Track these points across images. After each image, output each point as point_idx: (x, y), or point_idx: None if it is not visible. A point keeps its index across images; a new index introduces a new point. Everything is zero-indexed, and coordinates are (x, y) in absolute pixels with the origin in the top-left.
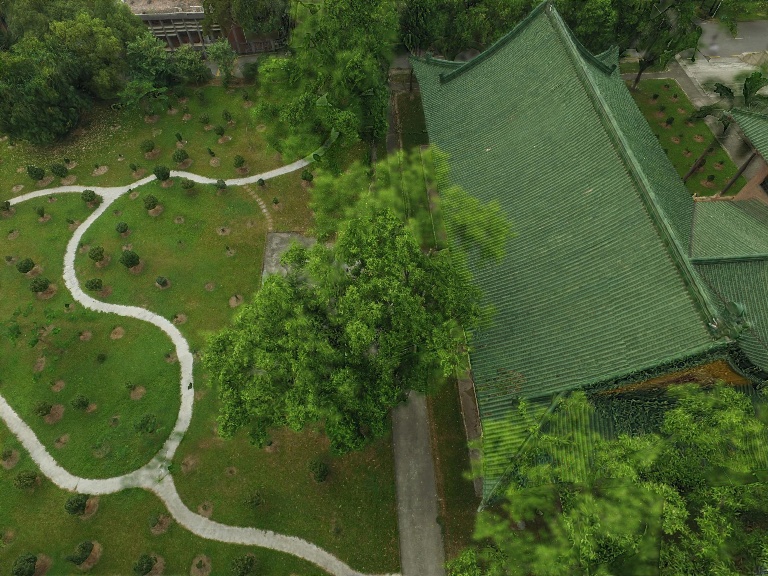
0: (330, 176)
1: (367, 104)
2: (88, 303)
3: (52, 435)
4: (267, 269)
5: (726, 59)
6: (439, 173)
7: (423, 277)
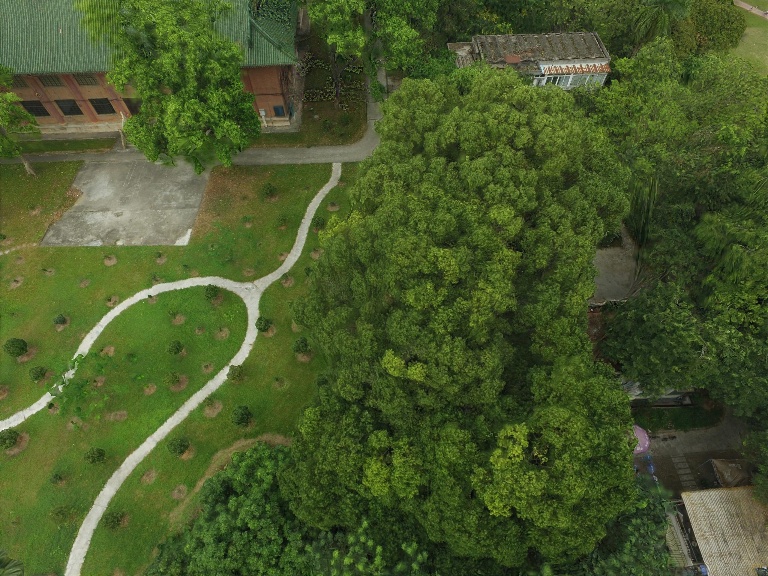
0: None
1: None
2: None
3: (199, 377)
4: (84, 244)
5: None
6: (62, 69)
7: (171, 4)
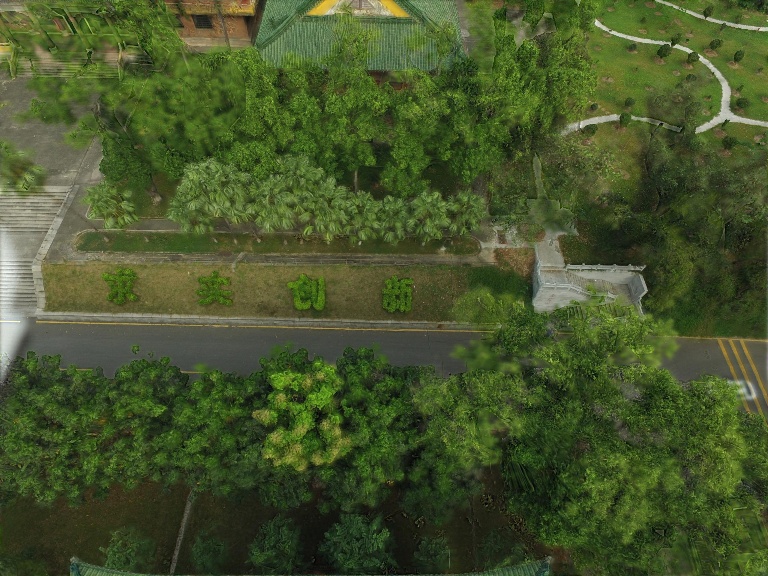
0: None
1: None
2: (676, 45)
3: None
4: None
5: None
6: None
7: None
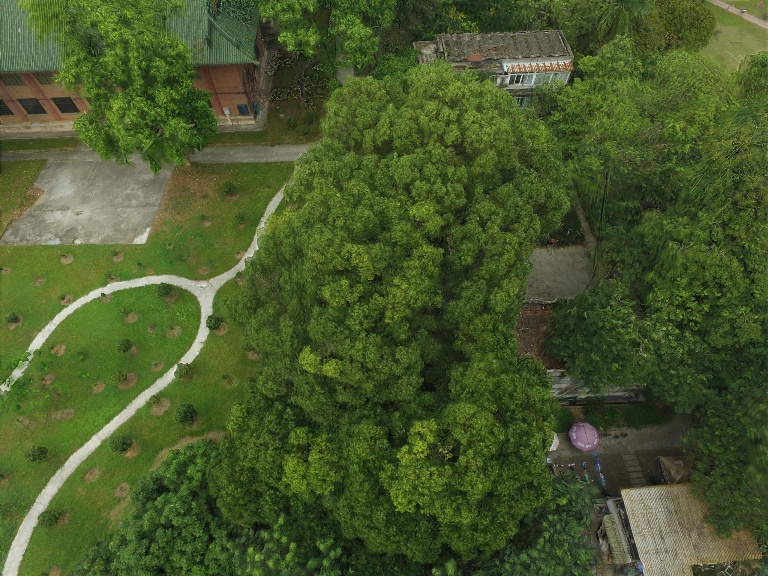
0: None
1: None
2: None
3: (148, 375)
4: (42, 242)
5: None
6: (21, 68)
7: (120, 2)
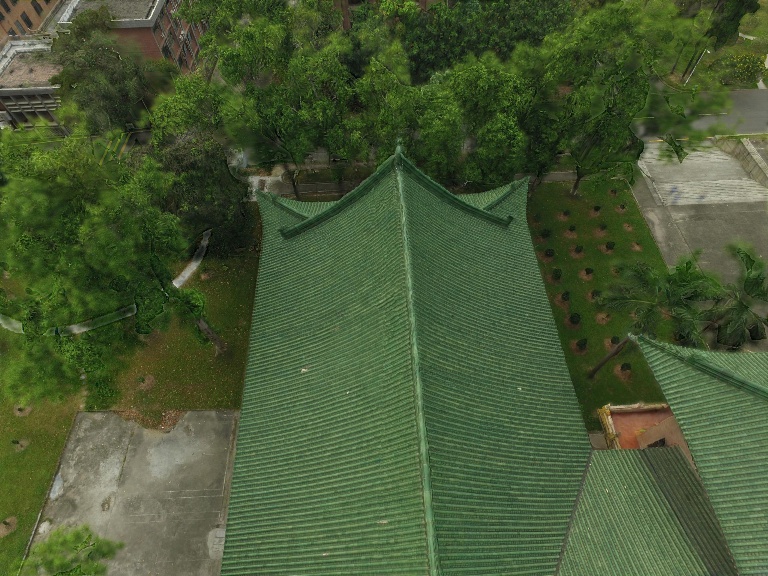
0: (177, 323)
1: (246, 215)
2: None
3: None
4: (63, 472)
5: (696, 142)
6: (246, 391)
7: None
